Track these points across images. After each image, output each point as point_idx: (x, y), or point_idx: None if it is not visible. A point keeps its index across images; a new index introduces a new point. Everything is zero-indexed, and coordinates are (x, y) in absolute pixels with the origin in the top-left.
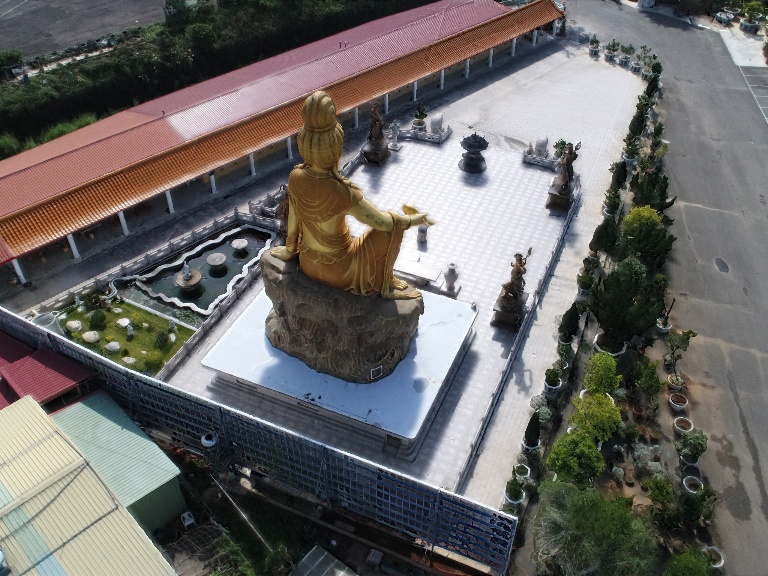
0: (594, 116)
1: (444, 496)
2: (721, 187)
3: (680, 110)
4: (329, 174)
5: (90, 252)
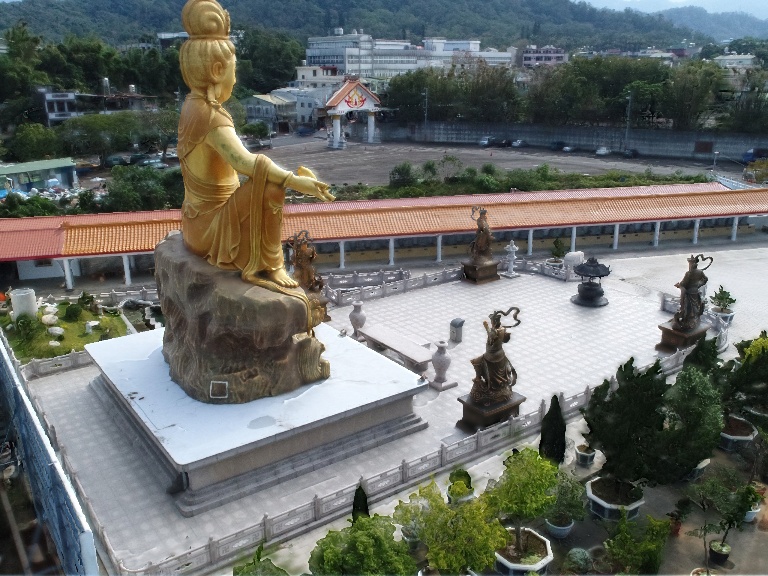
0: None
1: None
2: None
3: None
4: (203, 97)
5: (141, 283)
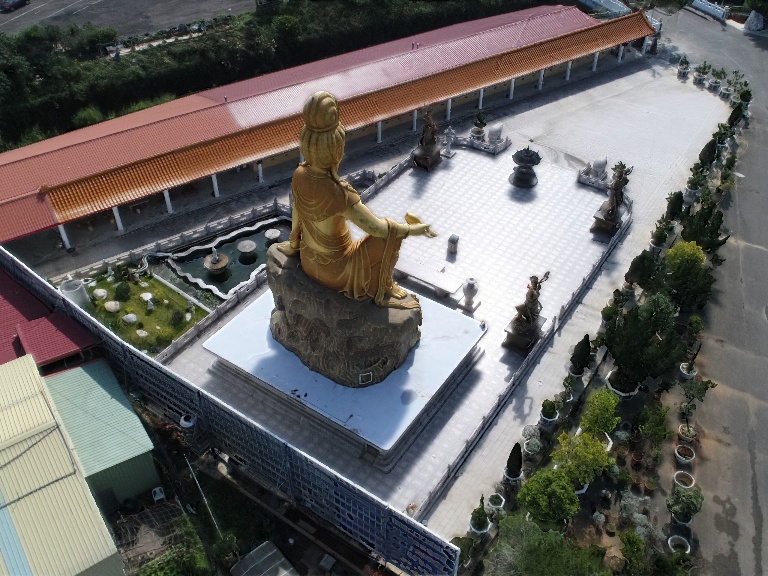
0: (667, 141)
1: (393, 513)
2: None
3: (765, 143)
4: (328, 175)
5: (133, 226)
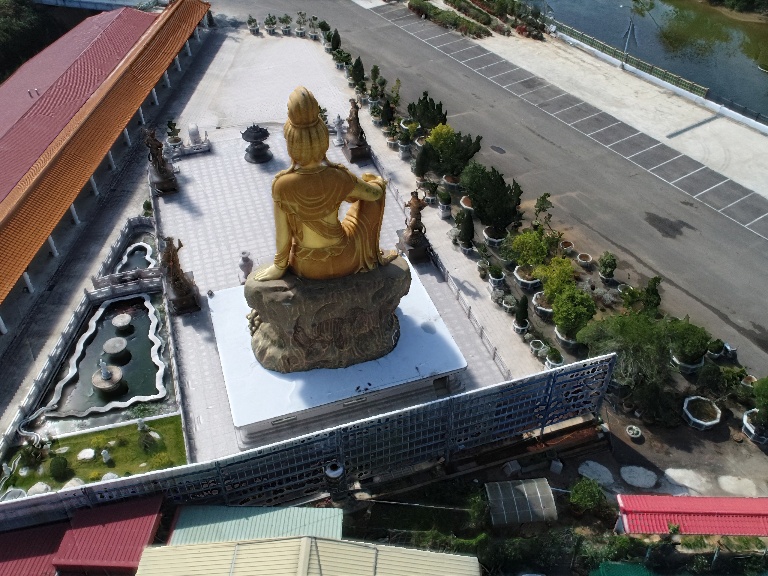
0: (308, 81)
1: None
2: (445, 98)
3: (363, 54)
4: (323, 166)
5: None
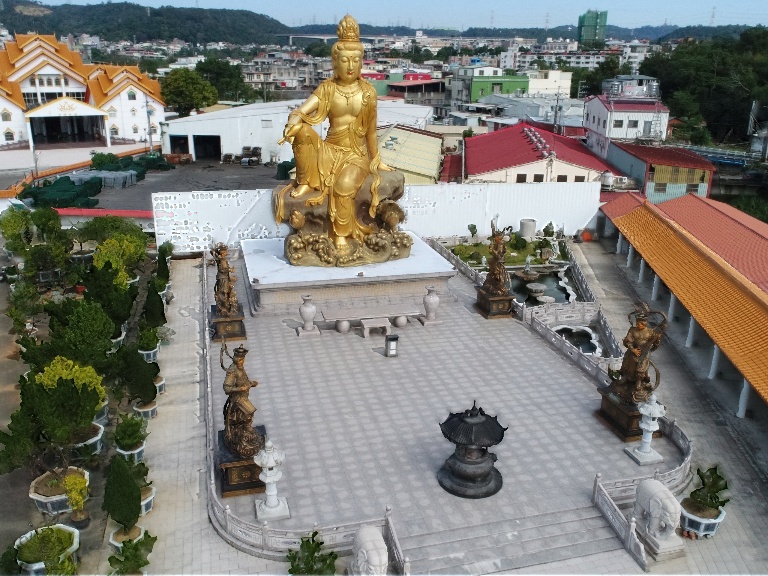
0: None
1: None
2: None
3: None
4: None
5: None
